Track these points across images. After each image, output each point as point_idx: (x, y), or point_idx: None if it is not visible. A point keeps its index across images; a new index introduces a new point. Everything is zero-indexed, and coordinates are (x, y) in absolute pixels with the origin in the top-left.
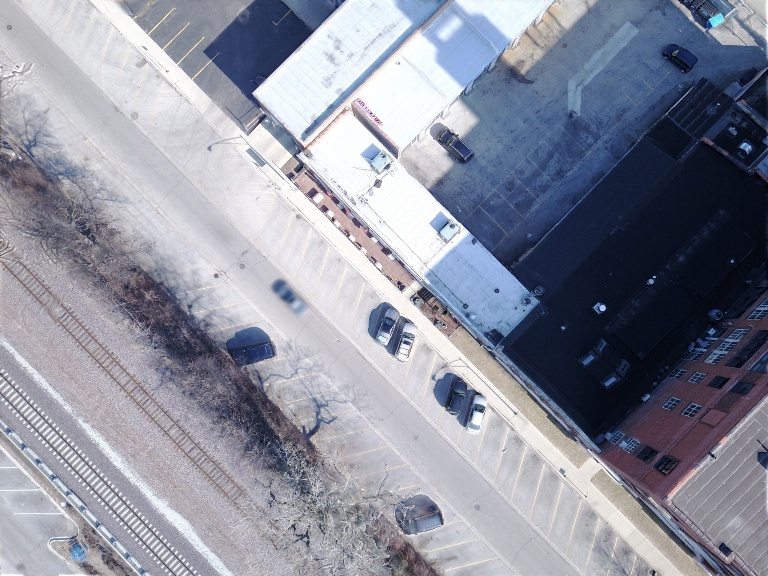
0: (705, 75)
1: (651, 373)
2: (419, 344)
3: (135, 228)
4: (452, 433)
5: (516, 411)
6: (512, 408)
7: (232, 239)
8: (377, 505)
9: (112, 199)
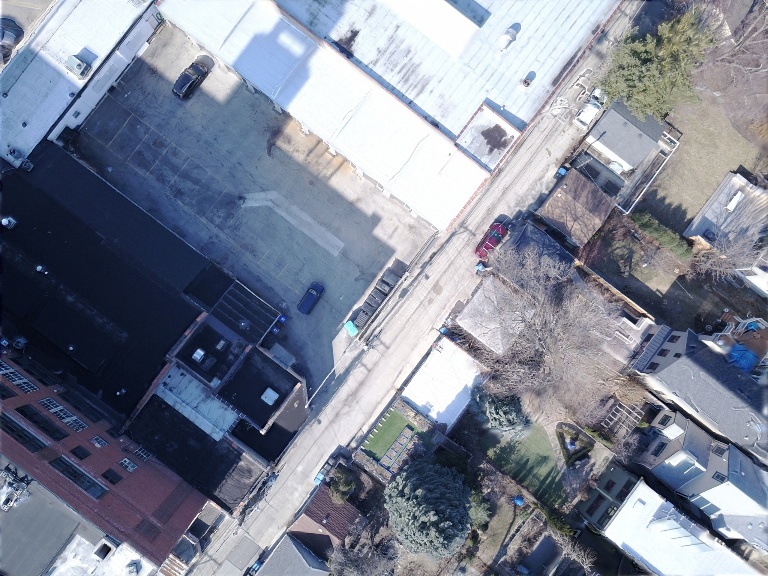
0: (299, 328)
1: None
2: None
3: None
4: None
5: None
6: None
7: None
8: None
9: None
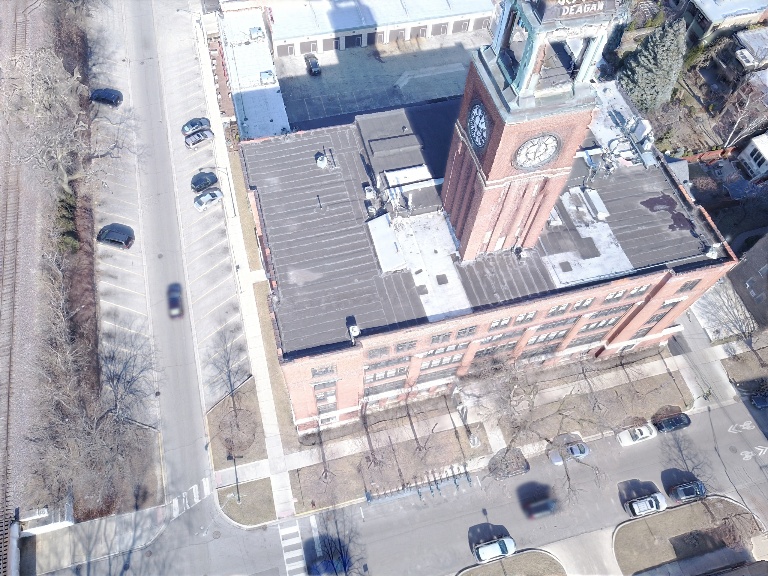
0: None
1: None
2: (208, 148)
3: (103, 20)
4: (184, 205)
5: (237, 215)
6: (236, 212)
7: (150, 50)
8: (96, 216)
9: (105, 3)
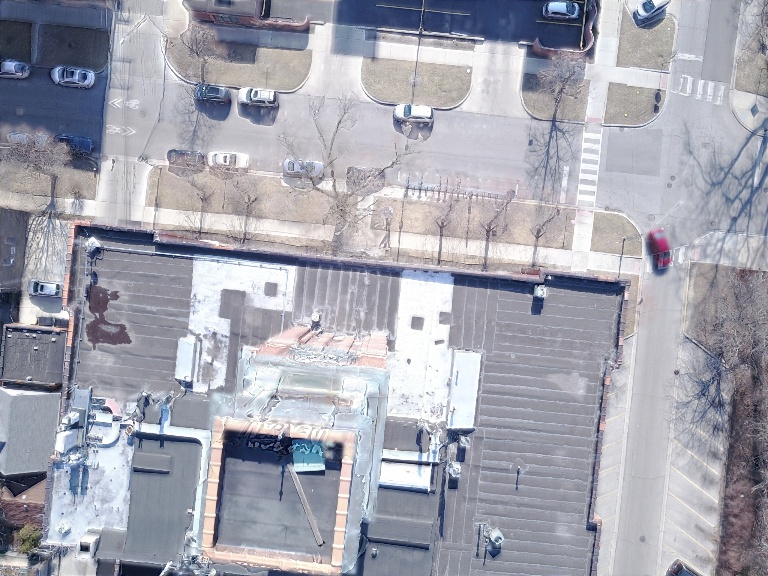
0: None
1: None
2: None
3: None
4: None
5: None
6: None
7: None
8: None
9: None
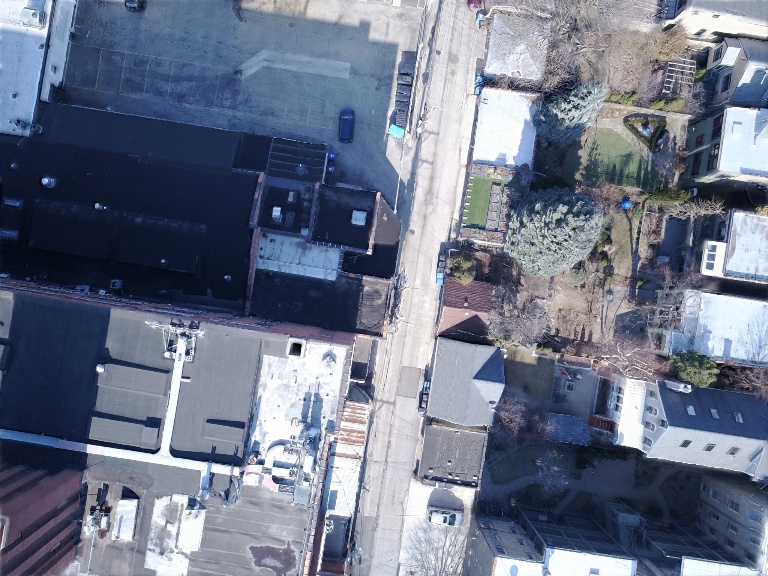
0: (350, 159)
1: (32, 268)
2: None
3: None
4: None
5: None
6: None
7: None
8: None
9: None
